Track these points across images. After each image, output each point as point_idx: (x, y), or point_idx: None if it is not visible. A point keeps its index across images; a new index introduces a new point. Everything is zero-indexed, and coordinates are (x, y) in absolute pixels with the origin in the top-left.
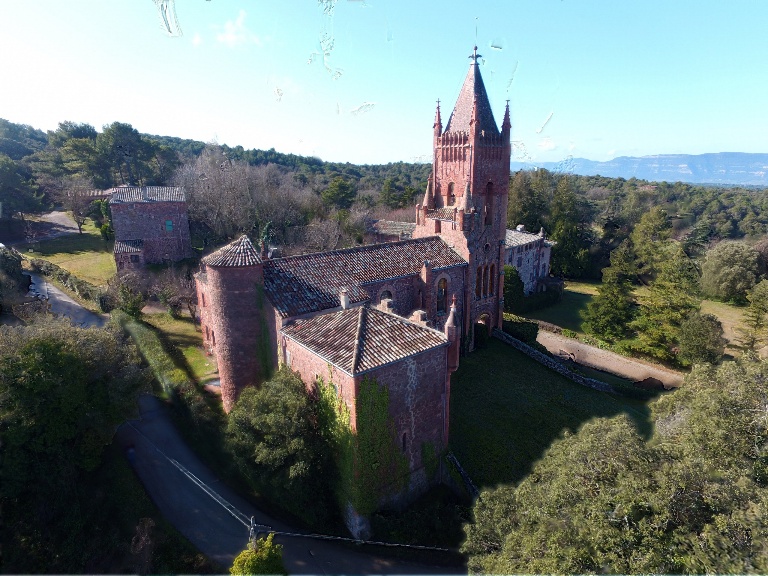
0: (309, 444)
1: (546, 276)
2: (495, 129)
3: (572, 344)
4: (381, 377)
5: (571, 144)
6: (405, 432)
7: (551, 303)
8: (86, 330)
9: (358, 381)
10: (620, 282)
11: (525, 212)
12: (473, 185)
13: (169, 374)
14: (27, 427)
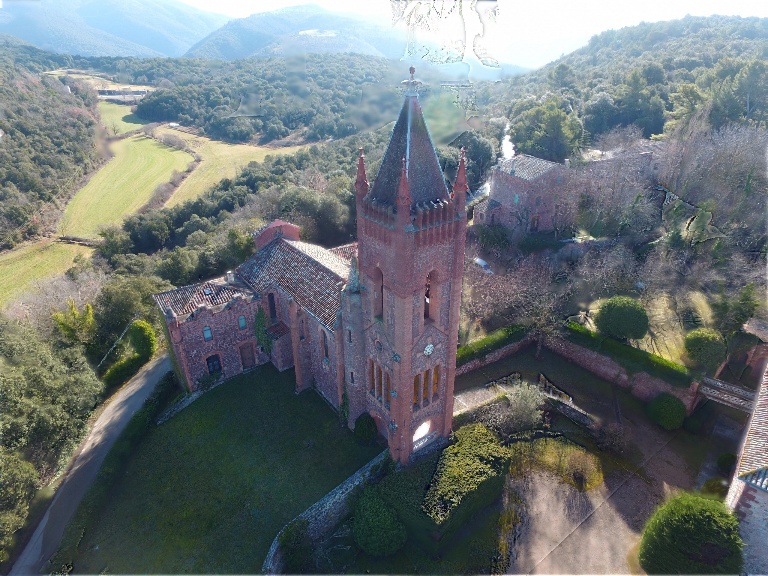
0: None
1: None
2: None
3: None
4: None
5: None
6: None
7: None
8: None
9: None
10: None
11: None
12: (359, 259)
13: None
14: None
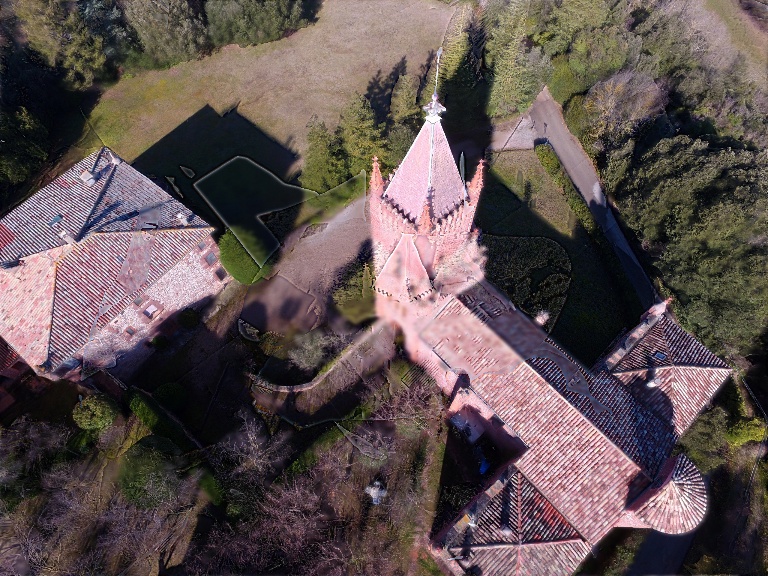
0: None
1: None
2: None
3: None
4: None
5: None
6: None
7: None
8: None
9: None
10: None
11: None
12: None
13: None
14: None
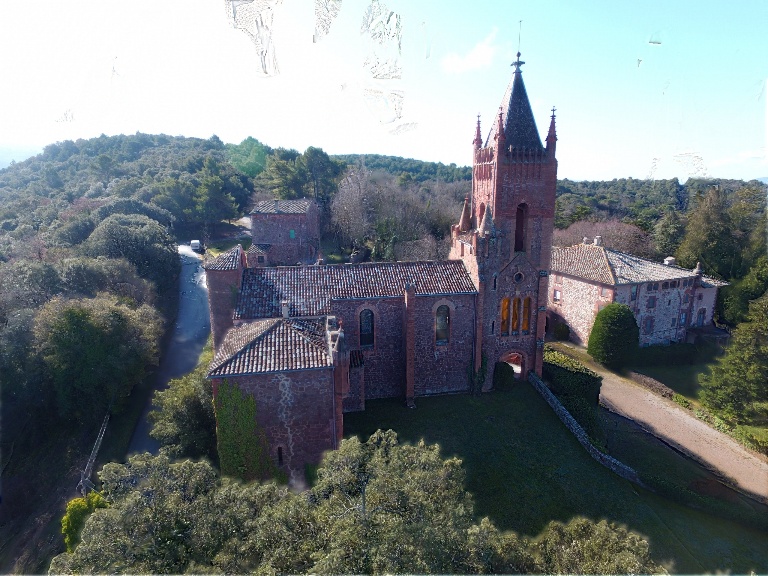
0: (197, 432)
1: (707, 325)
2: (537, 143)
3: (677, 415)
4: (245, 385)
5: None
6: (280, 446)
7: (699, 360)
8: (117, 307)
9: (217, 383)
10: (757, 345)
11: (711, 242)
12: (496, 206)
13: (203, 354)
14: (62, 369)
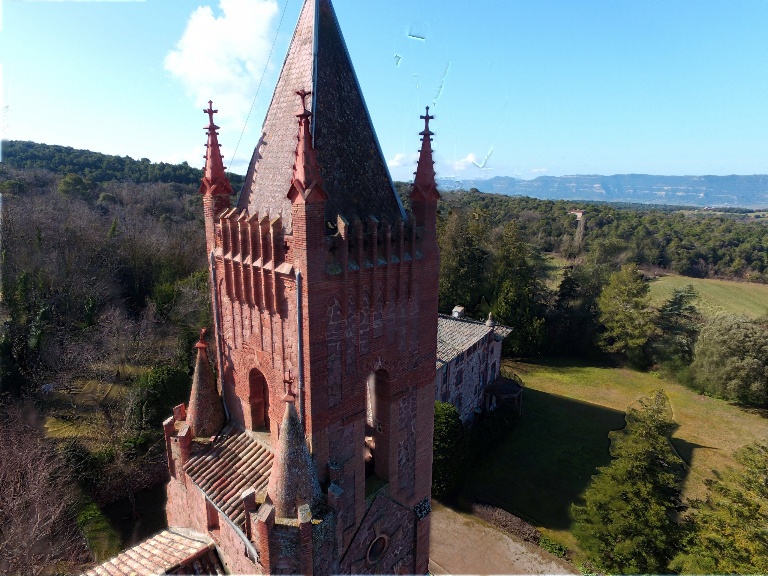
0: None
1: (496, 378)
2: (391, 202)
3: None
4: None
5: (517, 178)
6: None
7: (507, 431)
8: None
9: None
10: (649, 469)
11: (462, 268)
12: (313, 404)
13: None
14: None
